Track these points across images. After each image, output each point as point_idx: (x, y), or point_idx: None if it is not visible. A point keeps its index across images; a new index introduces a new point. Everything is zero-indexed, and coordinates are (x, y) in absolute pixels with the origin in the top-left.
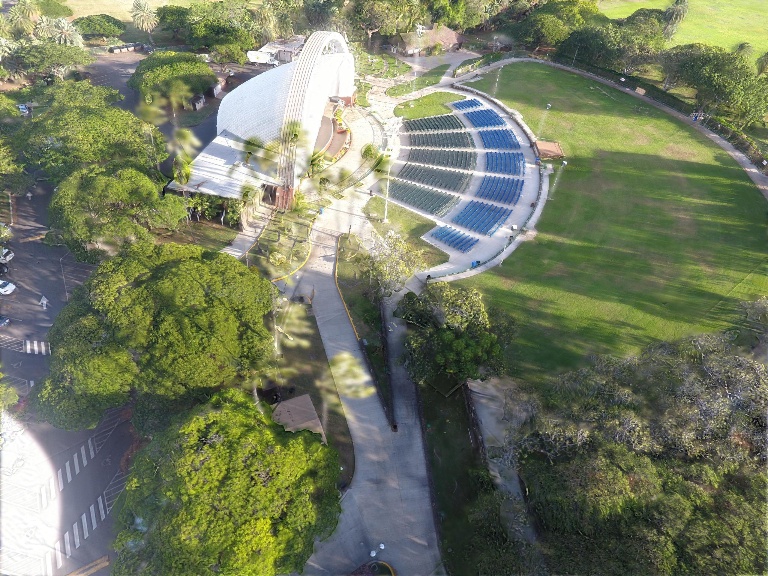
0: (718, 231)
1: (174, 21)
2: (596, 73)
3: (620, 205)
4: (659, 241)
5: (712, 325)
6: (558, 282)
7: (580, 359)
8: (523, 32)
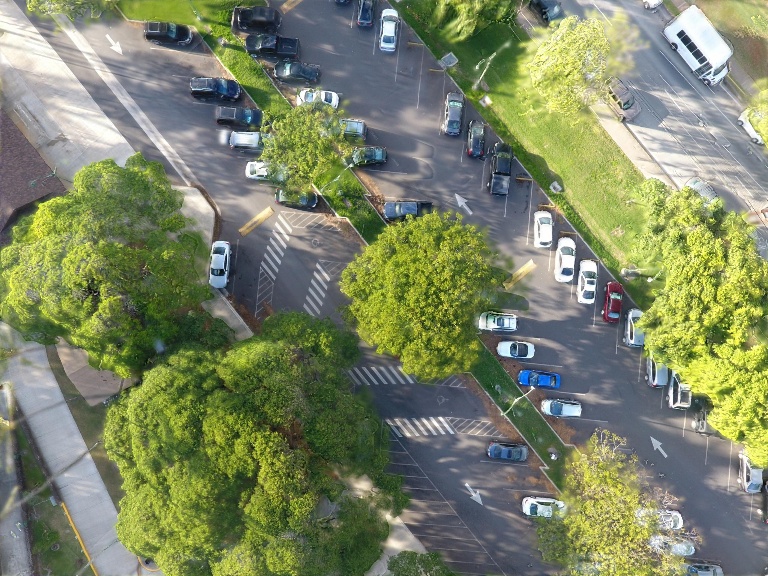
0: None
1: None
2: None
3: None
4: None
5: None
6: None
7: None
8: None
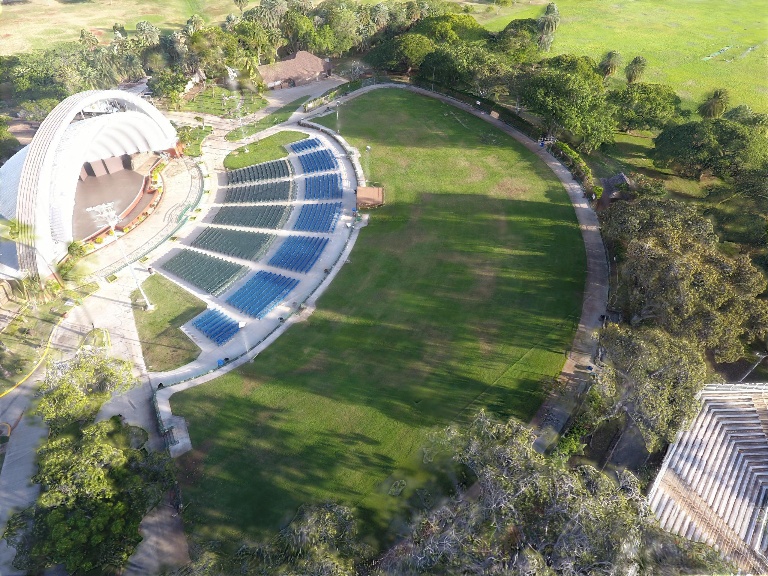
0: (516, 291)
1: (6, 73)
2: (454, 96)
3: (422, 264)
4: (446, 311)
5: (460, 430)
6: (307, 380)
7: (282, 498)
8: (387, 55)
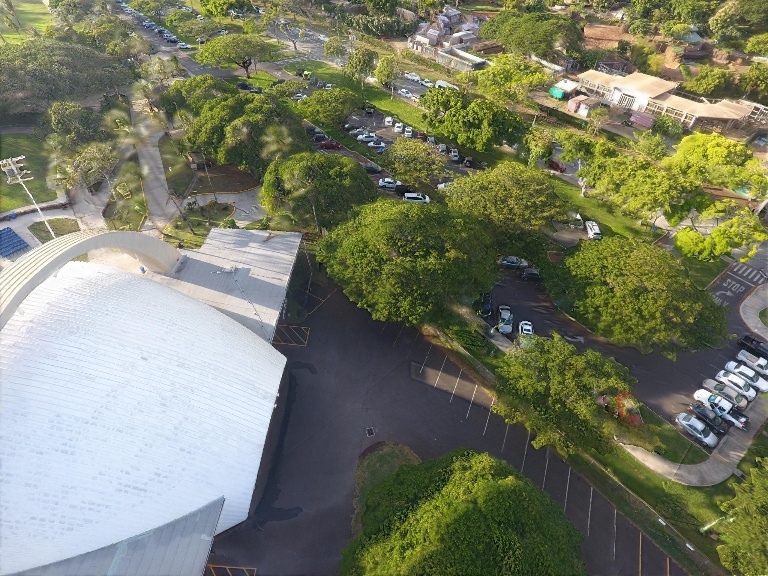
0: None
1: None
2: None
3: None
4: None
5: None
6: None
7: None
8: None
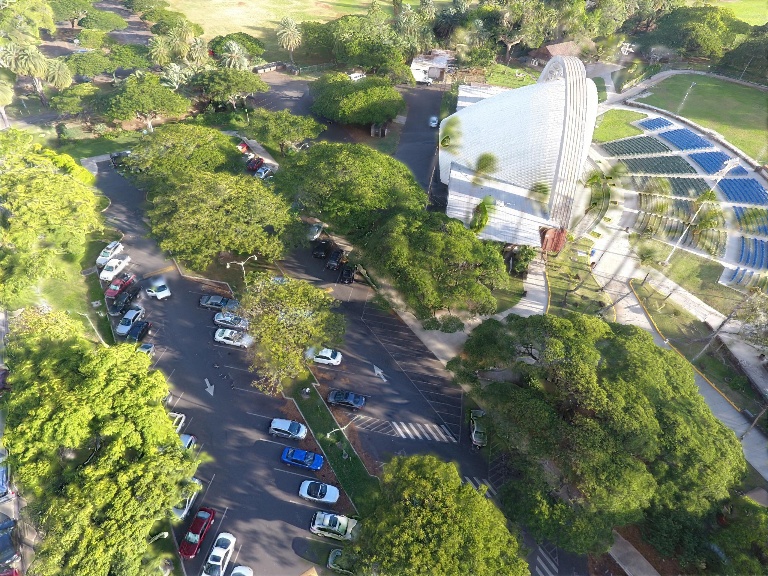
0: None
1: (316, 38)
2: None
3: None
4: None
5: None
6: None
7: None
8: (674, 42)
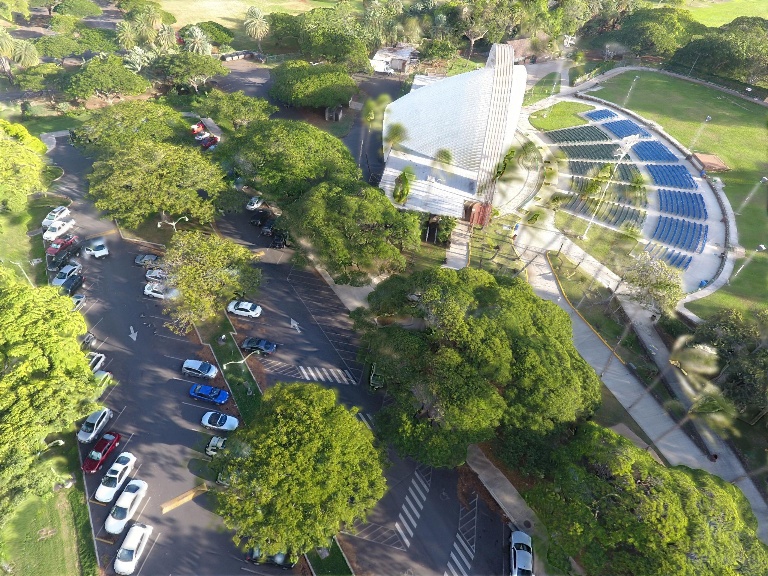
0: None
1: (283, 29)
2: (717, 82)
3: None
4: None
5: None
6: None
7: None
8: (630, 40)
